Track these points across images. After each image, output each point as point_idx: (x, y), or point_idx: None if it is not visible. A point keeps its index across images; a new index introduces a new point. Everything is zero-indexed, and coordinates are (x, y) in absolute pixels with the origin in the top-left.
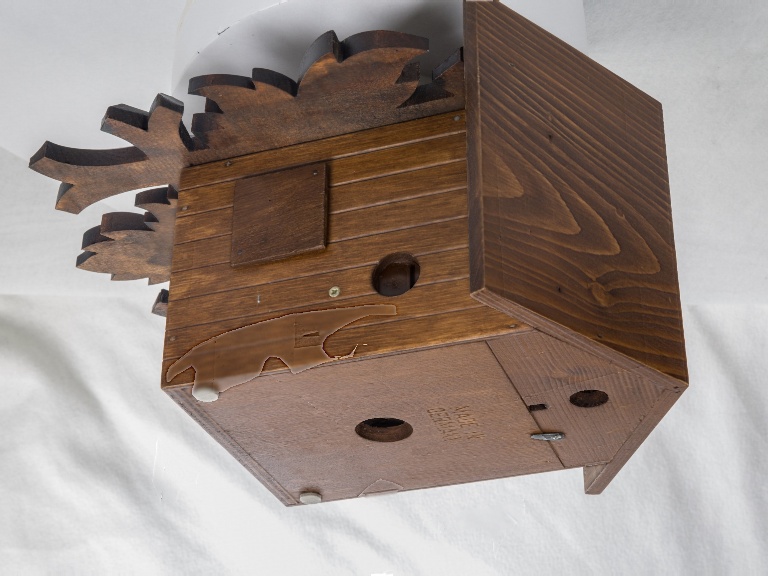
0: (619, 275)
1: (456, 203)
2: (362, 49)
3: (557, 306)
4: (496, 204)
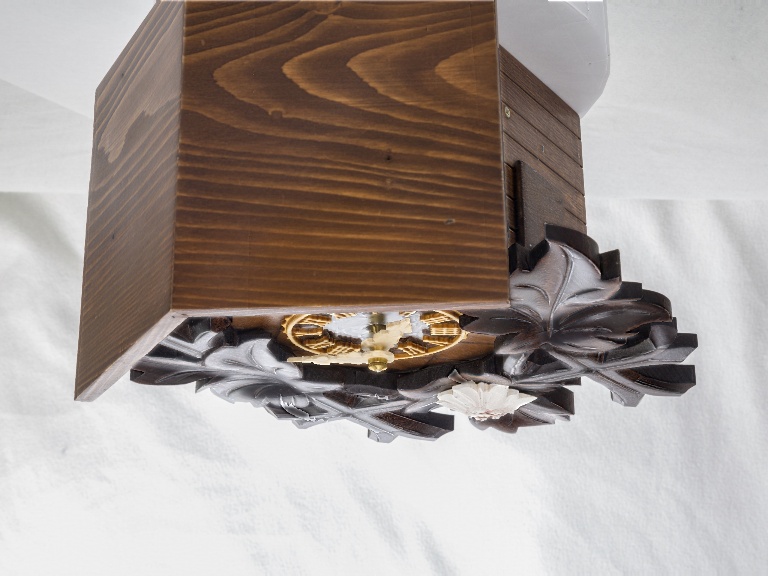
0: (288, 37)
1: None
2: None
3: None
4: (476, 38)
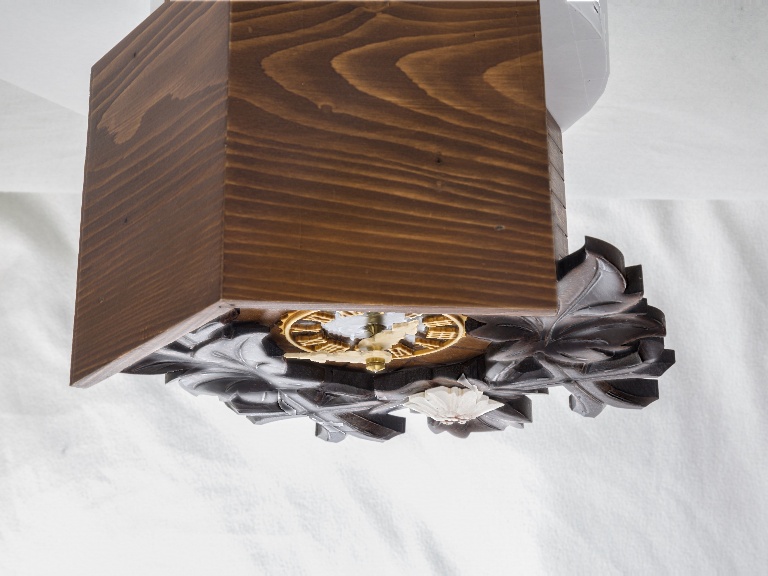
0: (337, 32)
1: None
2: None
3: None
4: (523, 48)
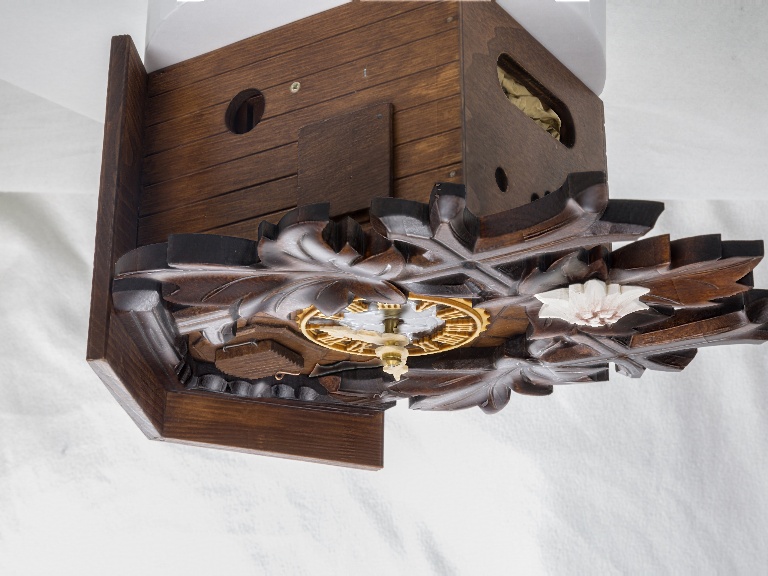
0: None
1: (192, 188)
2: (151, 247)
3: None
4: None
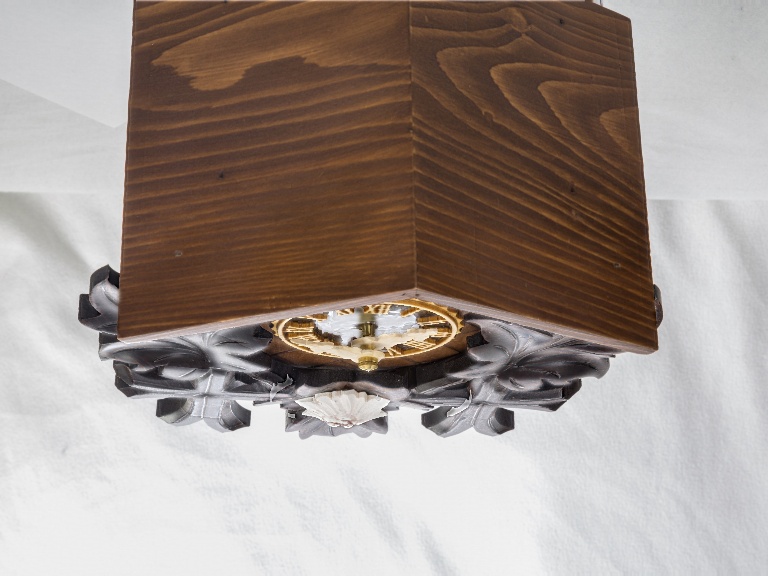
0: (493, 43)
1: None
2: None
3: (564, 6)
4: (625, 101)
